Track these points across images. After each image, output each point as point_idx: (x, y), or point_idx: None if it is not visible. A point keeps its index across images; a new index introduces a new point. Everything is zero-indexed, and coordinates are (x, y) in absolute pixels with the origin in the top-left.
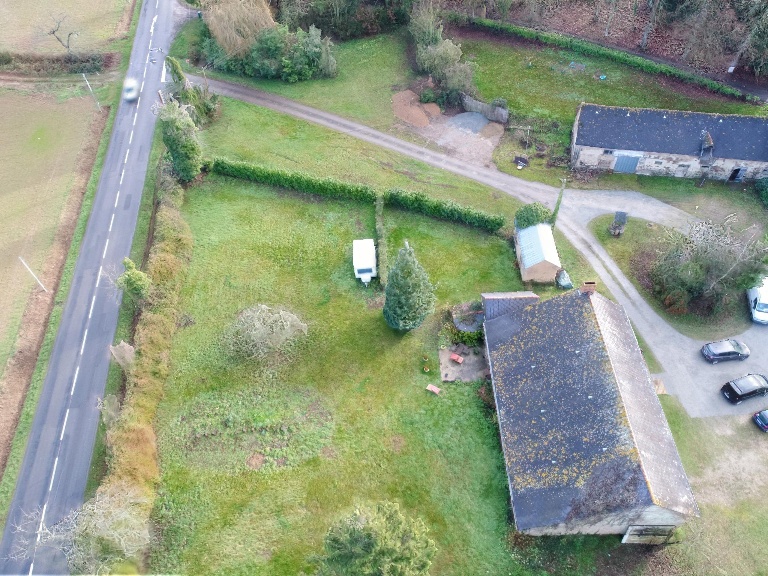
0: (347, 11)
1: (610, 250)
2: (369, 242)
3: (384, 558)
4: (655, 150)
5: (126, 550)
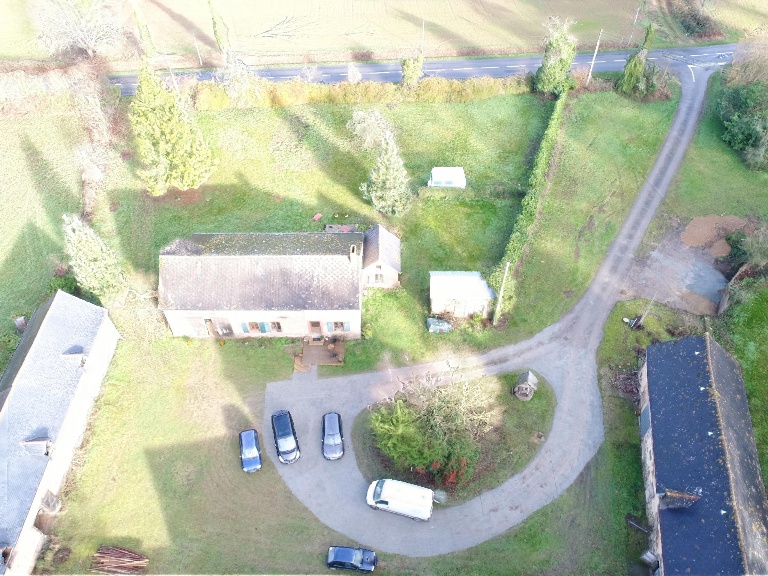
0: None
1: (489, 380)
2: (459, 175)
3: (140, 92)
4: (656, 433)
5: (229, 90)
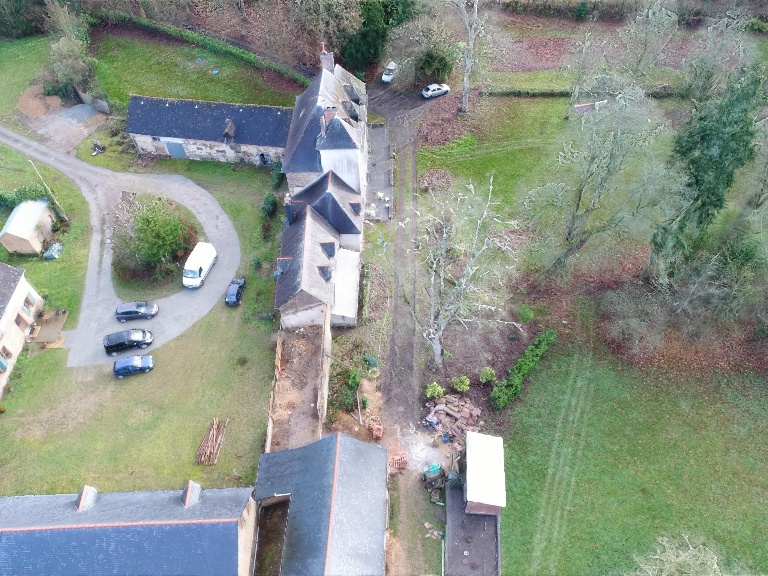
0: (18, 11)
1: None
2: None
3: None
4: (188, 137)
5: None
